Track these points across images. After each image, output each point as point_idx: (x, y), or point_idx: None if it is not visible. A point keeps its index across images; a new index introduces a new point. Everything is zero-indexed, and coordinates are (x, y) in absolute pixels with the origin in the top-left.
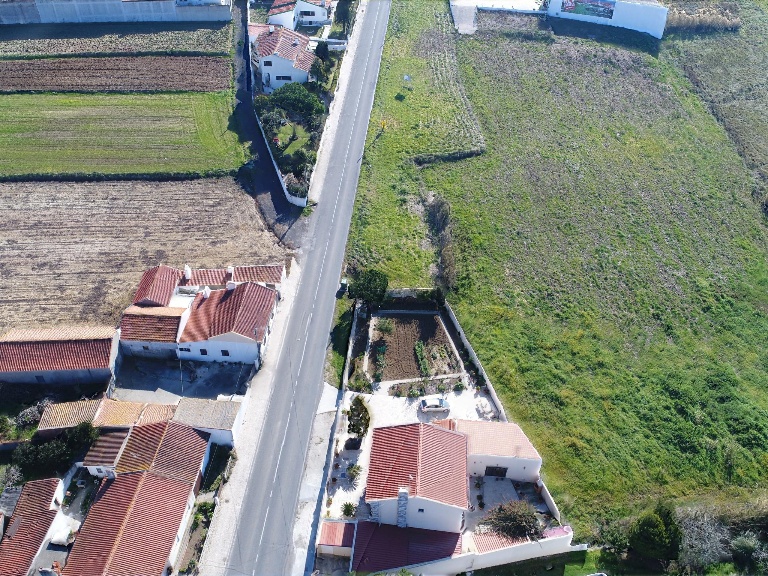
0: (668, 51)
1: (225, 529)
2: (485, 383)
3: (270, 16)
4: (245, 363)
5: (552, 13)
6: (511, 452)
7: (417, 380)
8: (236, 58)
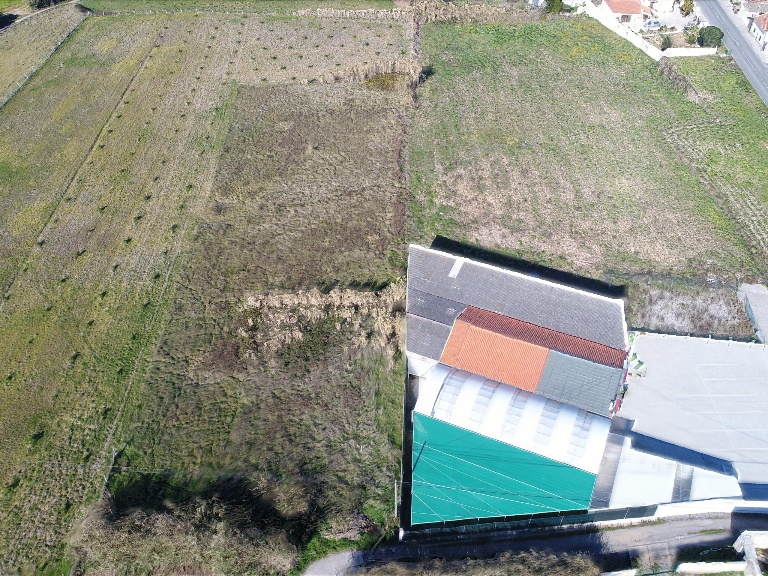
0: None
1: (724, 2)
2: None
3: None
4: None
5: None
6: (617, 1)
7: (665, 33)
8: None
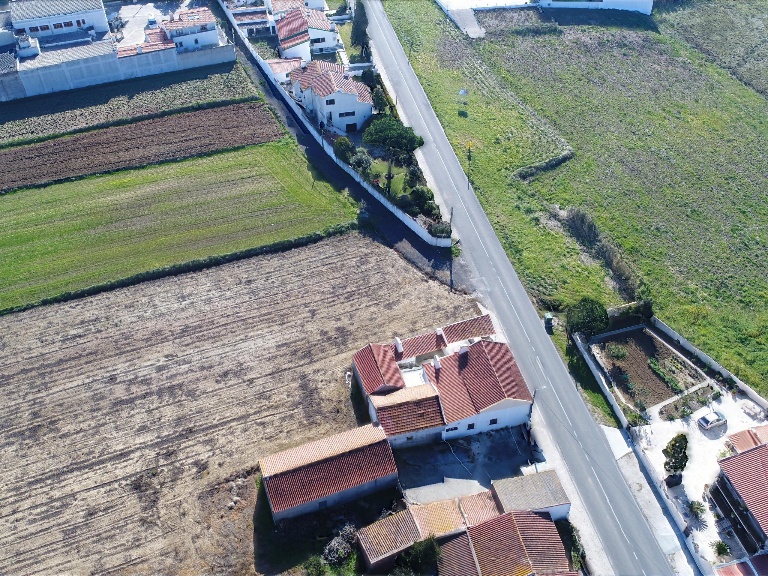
0: (663, 26)
1: None
2: (734, 385)
3: (286, 50)
4: (511, 426)
5: (544, 4)
6: None
7: (676, 399)
8: (269, 100)
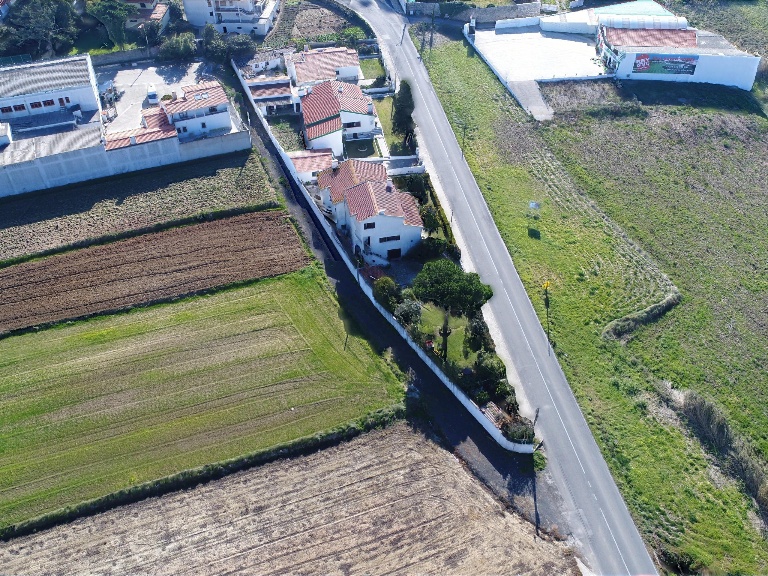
0: (767, 106)
1: None
2: None
3: (313, 140)
4: None
5: (621, 75)
6: None
7: None
8: (291, 208)
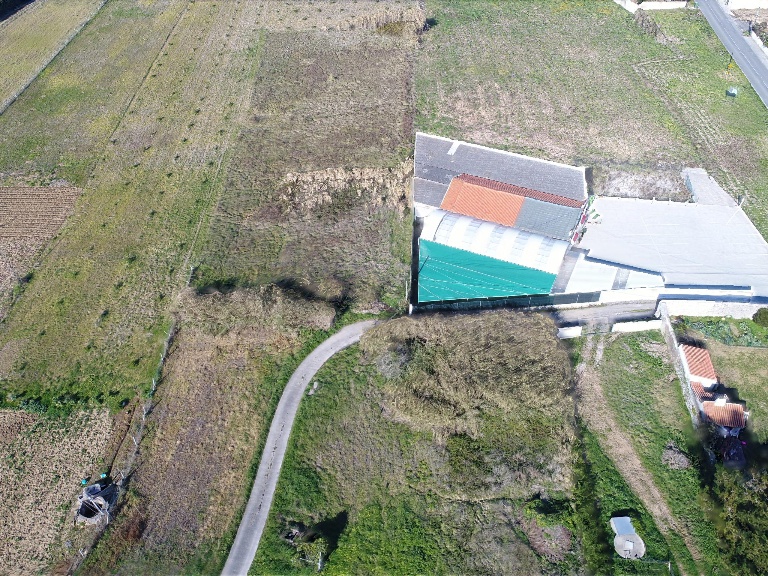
0: None
1: None
2: None
3: None
4: None
5: None
6: None
7: None
8: None
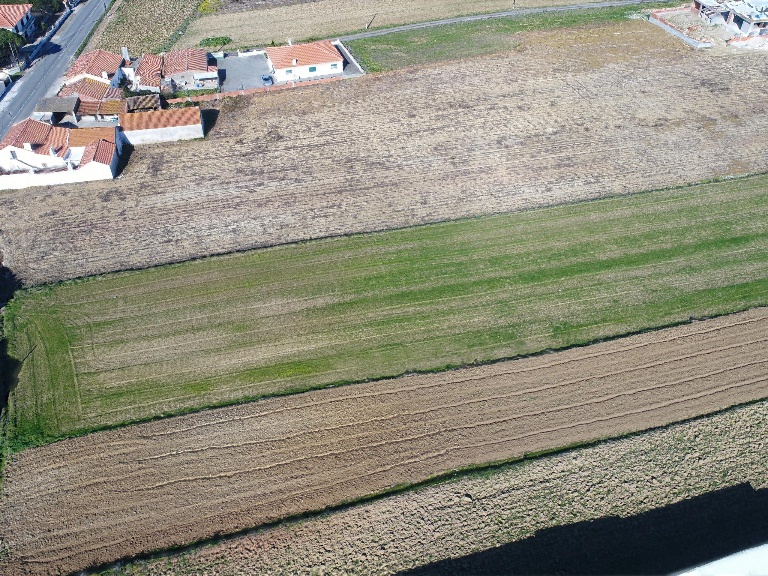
0: None
1: None
2: None
3: None
4: None
5: None
6: None
7: None
8: None
